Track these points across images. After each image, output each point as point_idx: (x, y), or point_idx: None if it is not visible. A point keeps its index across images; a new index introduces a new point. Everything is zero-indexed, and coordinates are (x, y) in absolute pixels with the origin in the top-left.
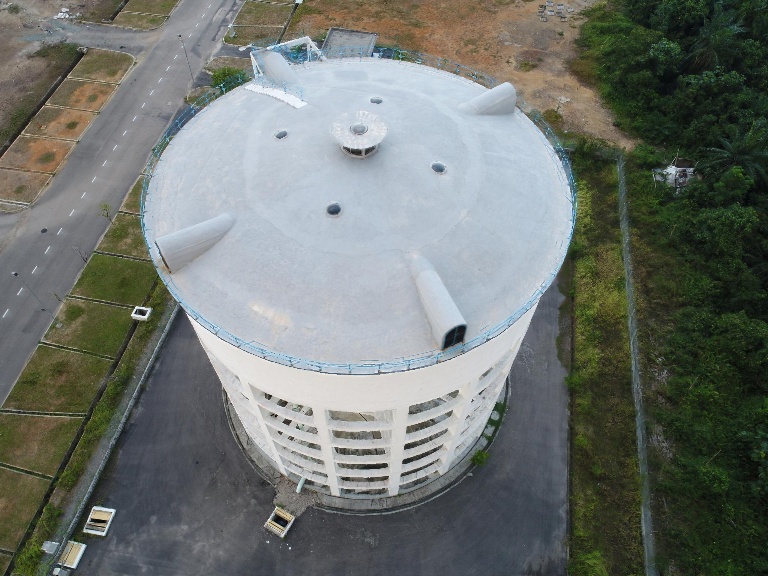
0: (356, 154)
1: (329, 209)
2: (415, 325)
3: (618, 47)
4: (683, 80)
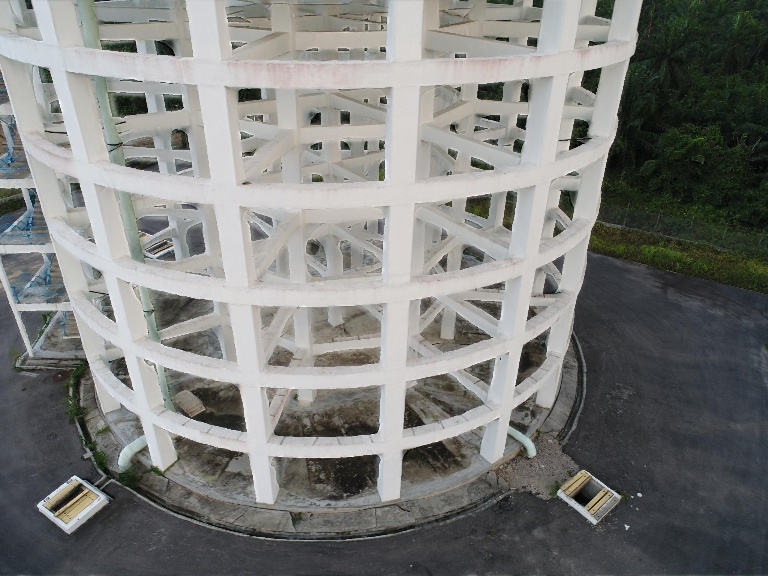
0: None
1: None
2: None
3: None
4: None
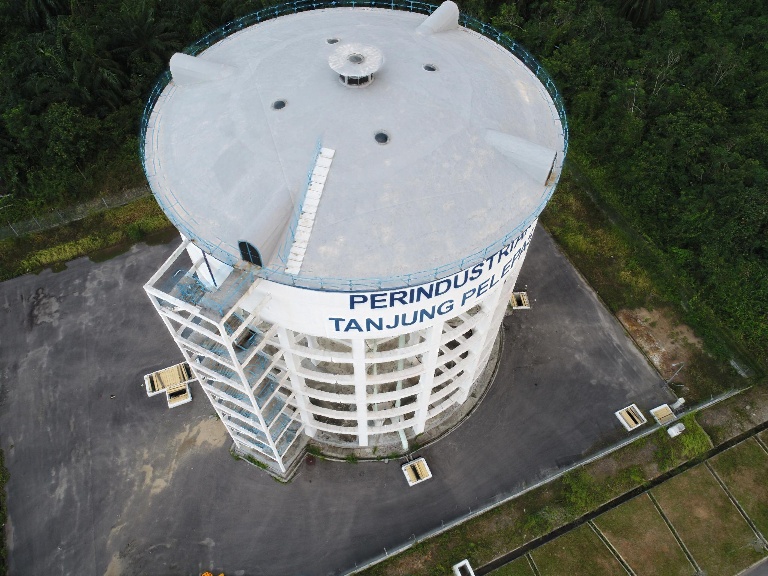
0: None
1: None
2: (457, 34)
3: None
4: None
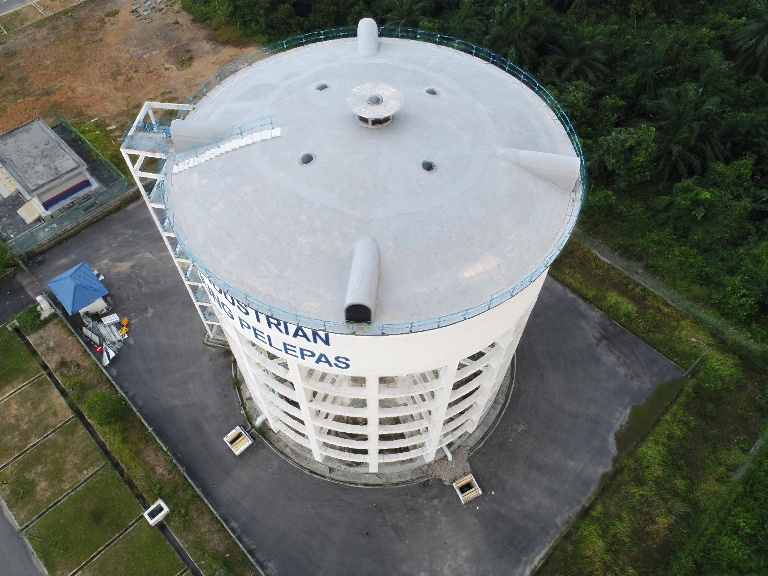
0: (386, 122)
1: (424, 169)
2: (548, 190)
3: (245, 0)
4: None
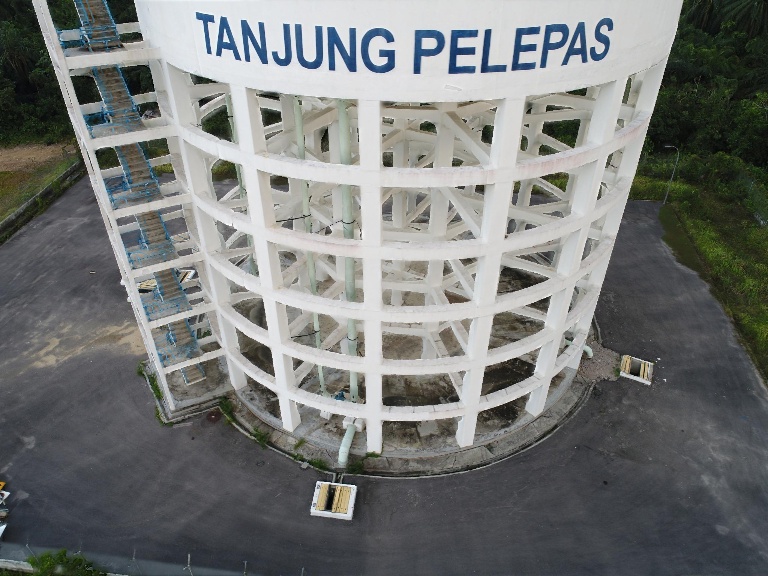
0: None
1: None
2: None
3: None
4: (39, 74)
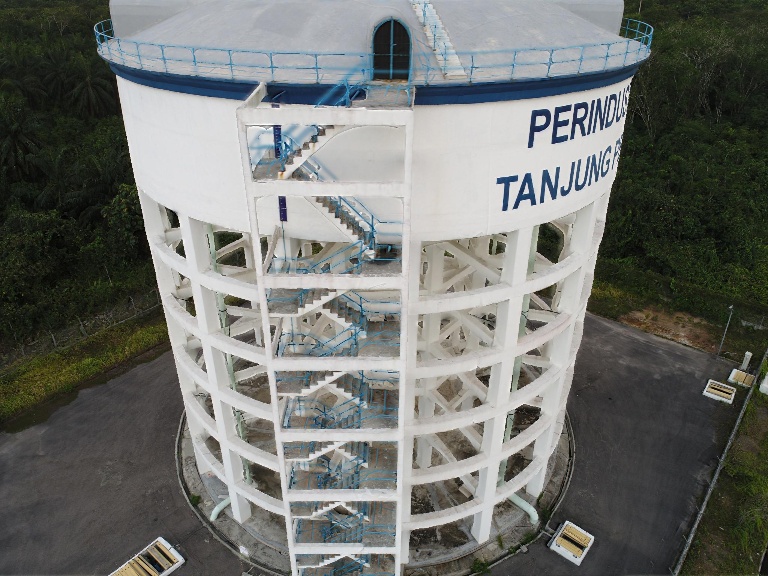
0: None
1: None
2: None
3: None
4: None
